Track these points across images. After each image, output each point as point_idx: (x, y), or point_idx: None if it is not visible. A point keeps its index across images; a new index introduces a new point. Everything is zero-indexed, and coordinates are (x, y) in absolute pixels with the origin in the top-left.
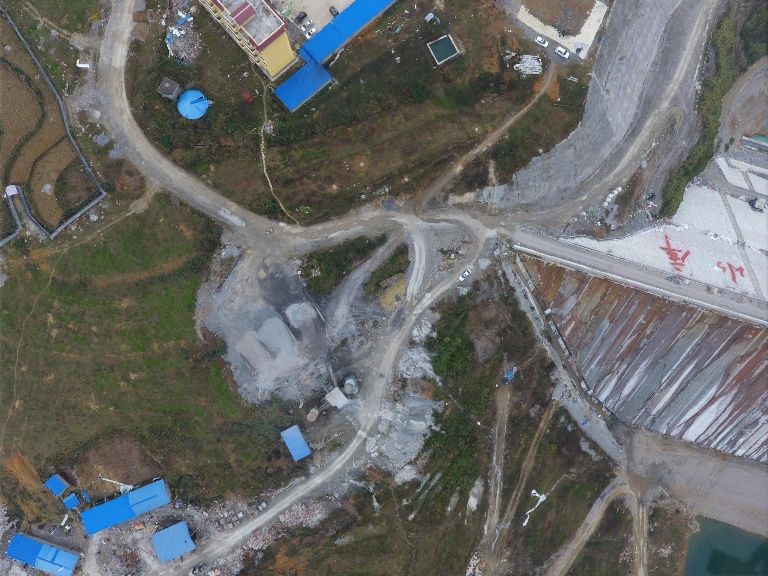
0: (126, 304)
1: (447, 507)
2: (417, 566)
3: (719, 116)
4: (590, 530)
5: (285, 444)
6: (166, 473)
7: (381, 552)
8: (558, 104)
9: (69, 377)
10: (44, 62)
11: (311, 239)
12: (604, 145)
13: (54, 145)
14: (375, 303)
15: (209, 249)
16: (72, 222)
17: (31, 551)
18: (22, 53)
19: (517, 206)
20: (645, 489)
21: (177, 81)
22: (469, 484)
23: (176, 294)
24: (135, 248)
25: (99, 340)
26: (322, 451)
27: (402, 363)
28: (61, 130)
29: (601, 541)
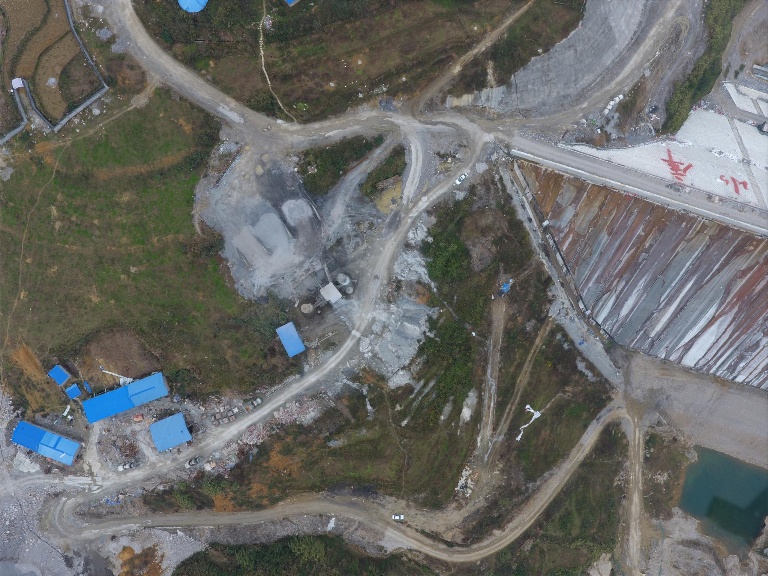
0: (127, 198)
1: (440, 416)
2: (409, 472)
3: (729, 38)
4: (585, 451)
5: (280, 342)
6: (164, 367)
7: (374, 456)
8: (559, 2)
9: (72, 269)
10: None
11: (308, 137)
12: (606, 52)
13: (58, 40)
14: (371, 205)
15: (208, 145)
16: (75, 116)
17: (34, 437)
18: None
19: (516, 111)
20: (642, 414)
21: None
22: (462, 393)
23: (175, 189)
24: (136, 142)
25: (100, 233)
26: (316, 349)
27: (397, 265)
28: (65, 26)
29: (596, 463)
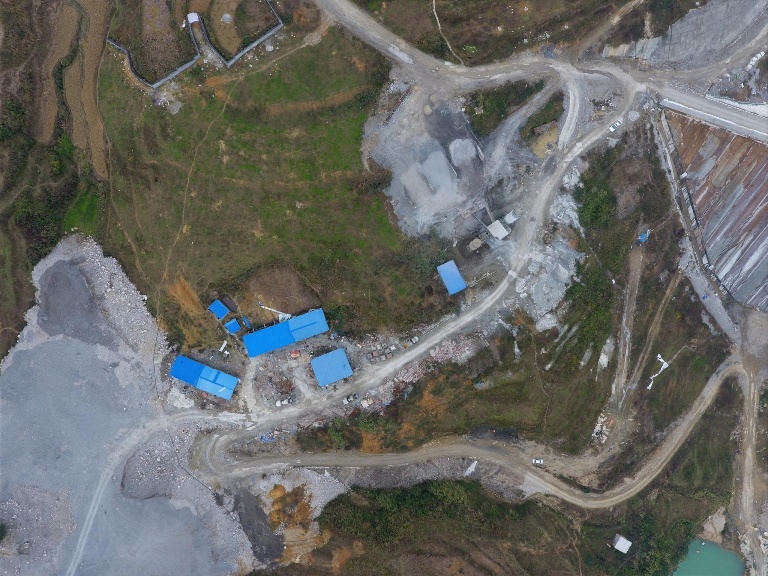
0: (296, 134)
1: (580, 361)
2: (550, 417)
3: None
4: (706, 403)
5: (438, 281)
6: (324, 303)
7: (518, 399)
8: None
9: (237, 204)
10: None
11: (474, 79)
12: (749, 10)
13: None
14: (528, 149)
15: (378, 83)
16: (249, 51)
17: (194, 371)
18: None
19: (665, 63)
20: (757, 369)
21: None
22: (603, 339)
23: (344, 126)
24: (308, 78)
25: (268, 168)
26: (474, 289)
27: (553, 208)
28: None
29: (715, 416)
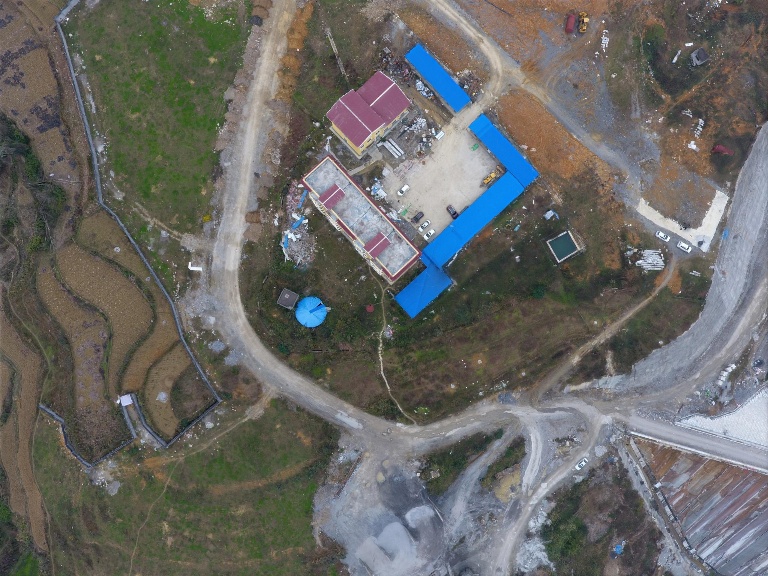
0: (243, 511)
1: None
2: None
3: None
4: None
5: None
6: None
7: None
8: (679, 297)
9: None
10: (154, 263)
11: (429, 438)
12: (717, 322)
13: (168, 352)
14: (490, 495)
15: None
16: (188, 430)
17: None
18: (132, 254)
19: (631, 389)
20: None
21: (295, 288)
22: None
23: (293, 499)
24: (252, 456)
25: (215, 547)
26: None
27: (519, 556)
28: (173, 334)
29: None
